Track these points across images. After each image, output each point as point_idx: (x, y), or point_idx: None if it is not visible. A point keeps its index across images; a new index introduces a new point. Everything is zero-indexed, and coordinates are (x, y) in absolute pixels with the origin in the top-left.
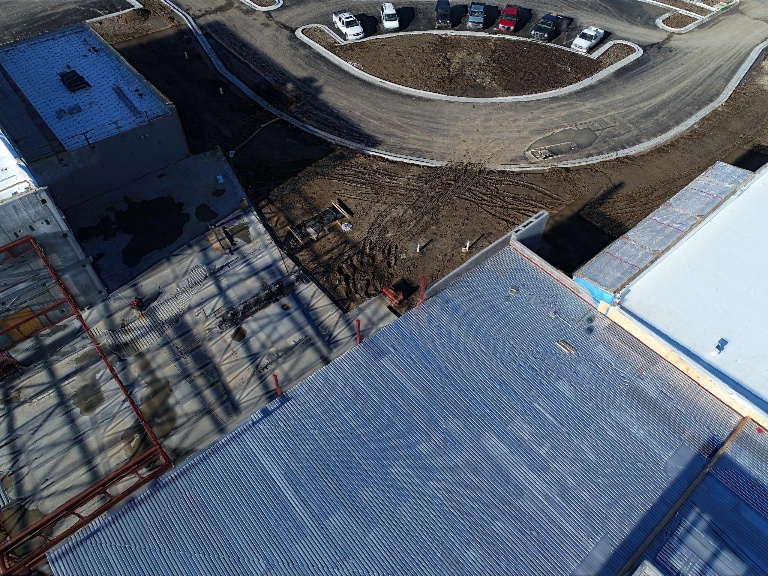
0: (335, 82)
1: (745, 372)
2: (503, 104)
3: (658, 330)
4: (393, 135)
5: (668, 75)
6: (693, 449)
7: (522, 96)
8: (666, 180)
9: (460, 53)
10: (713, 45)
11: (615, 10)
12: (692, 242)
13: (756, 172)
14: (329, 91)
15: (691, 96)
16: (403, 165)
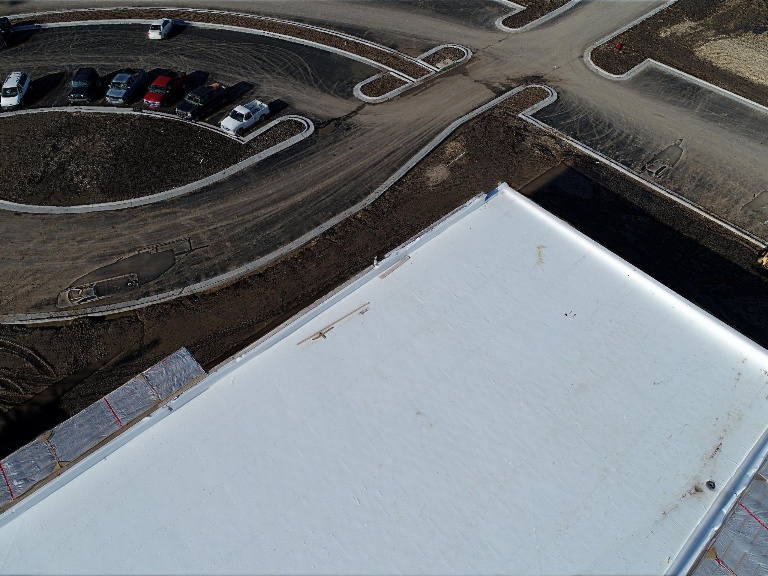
0: None
1: None
2: (84, 215)
3: None
4: None
5: (323, 165)
6: None
7: (115, 202)
8: (216, 335)
9: (79, 139)
10: (404, 120)
11: (314, 72)
12: (47, 504)
13: (212, 369)
14: None
15: (333, 196)
16: None
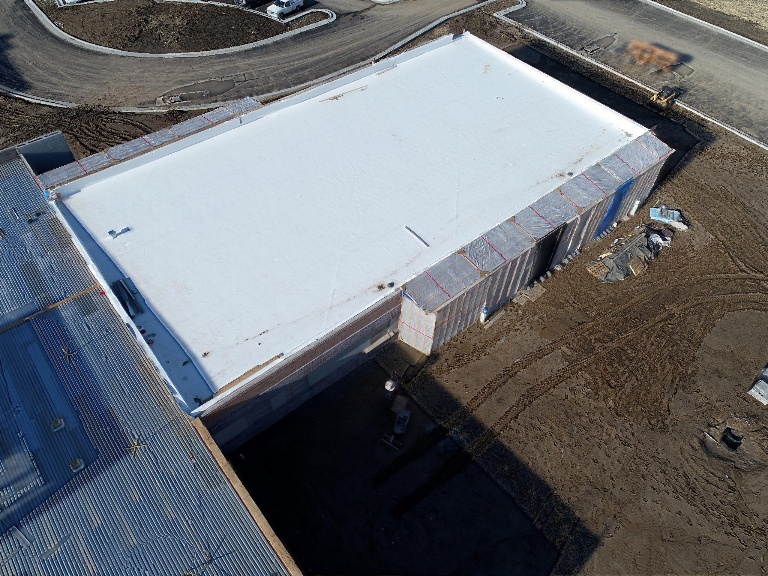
0: (29, 38)
1: (124, 252)
2: (170, 59)
3: (77, 220)
4: (48, 82)
5: (342, 38)
6: (37, 306)
7: (191, 53)
8: None
9: (163, 16)
10: (405, 14)
11: None
12: (170, 157)
13: (266, 104)
14: (18, 45)
15: (348, 56)
16: (36, 106)
